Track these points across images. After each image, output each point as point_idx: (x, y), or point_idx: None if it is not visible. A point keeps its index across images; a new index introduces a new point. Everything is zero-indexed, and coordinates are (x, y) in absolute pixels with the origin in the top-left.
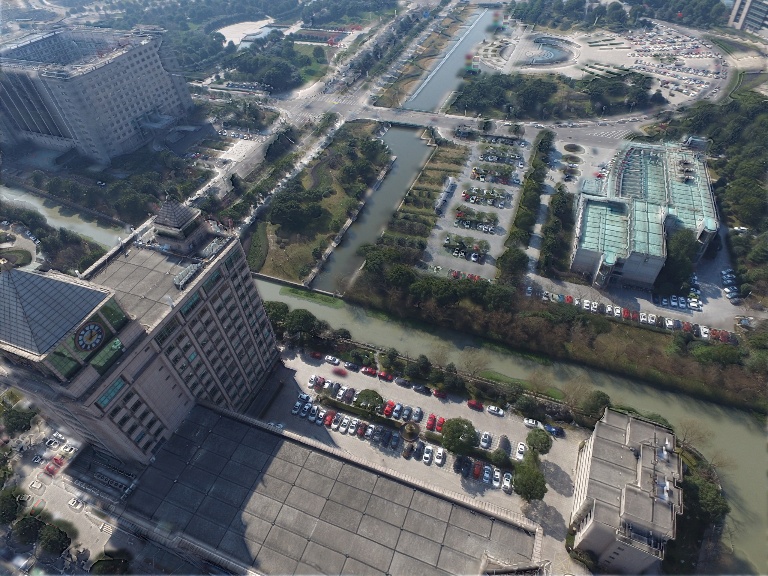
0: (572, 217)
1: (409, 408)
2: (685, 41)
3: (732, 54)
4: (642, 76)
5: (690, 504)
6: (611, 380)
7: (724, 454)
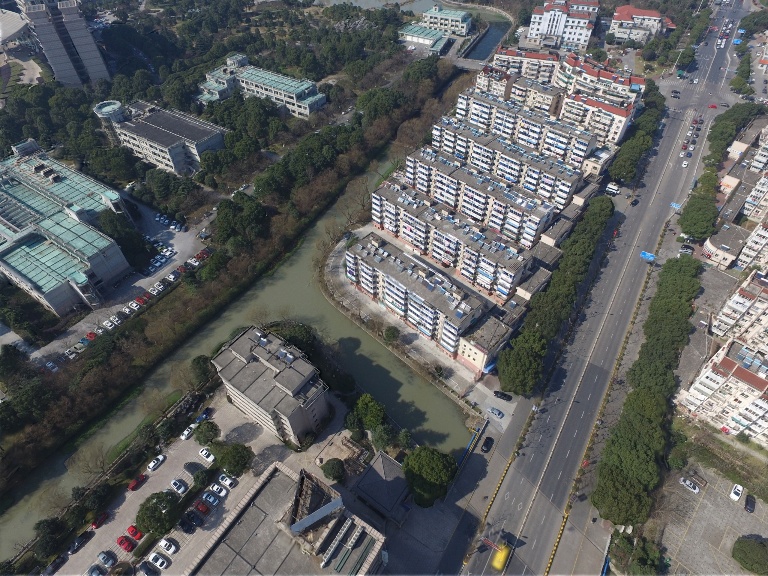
0: None
1: (92, 568)
2: None
3: None
4: None
5: (303, 348)
6: (190, 347)
7: (283, 308)
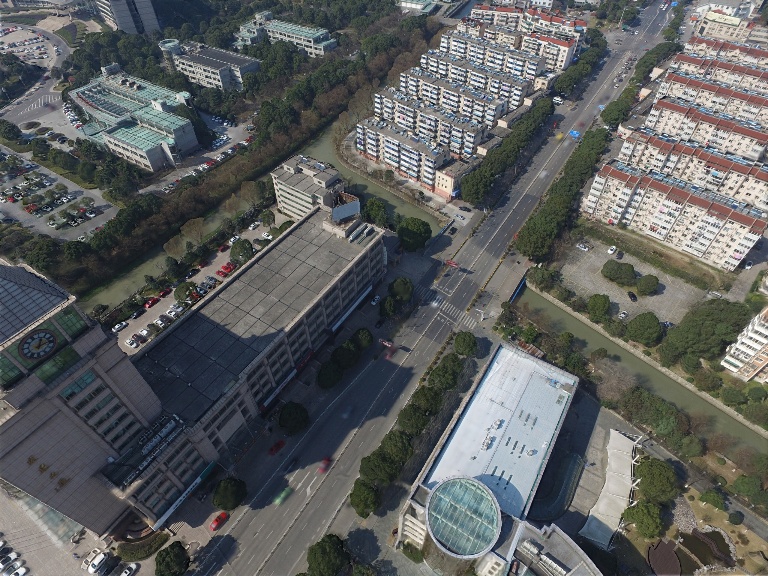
0: (105, 153)
1: (203, 283)
2: None
3: (25, 23)
4: None
5: None
6: None
7: None
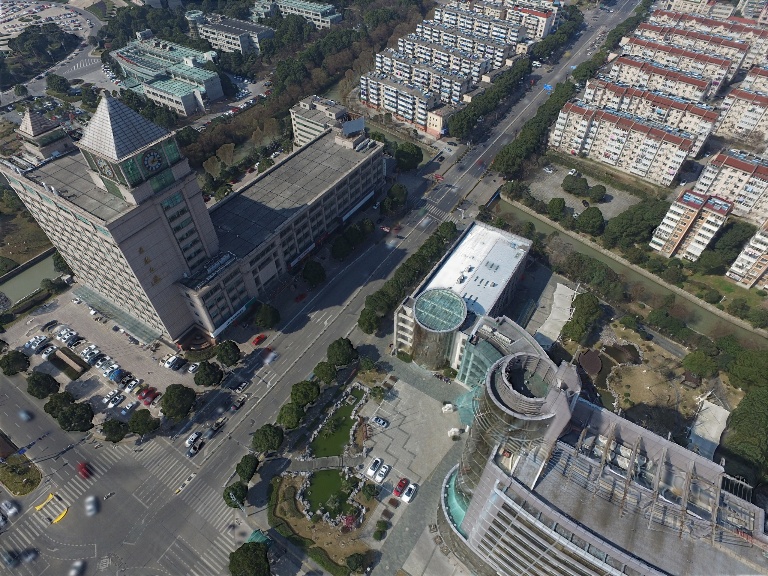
0: (144, 103)
1: None
2: (11, 5)
3: (58, 1)
4: (39, 26)
5: None
6: None
7: None
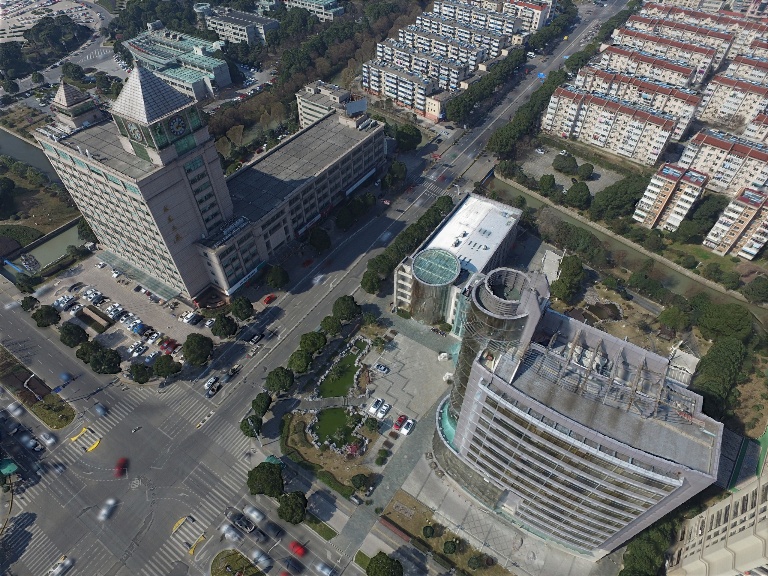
0: None
1: None
2: None
3: None
4: (52, 18)
5: None
6: None
7: None
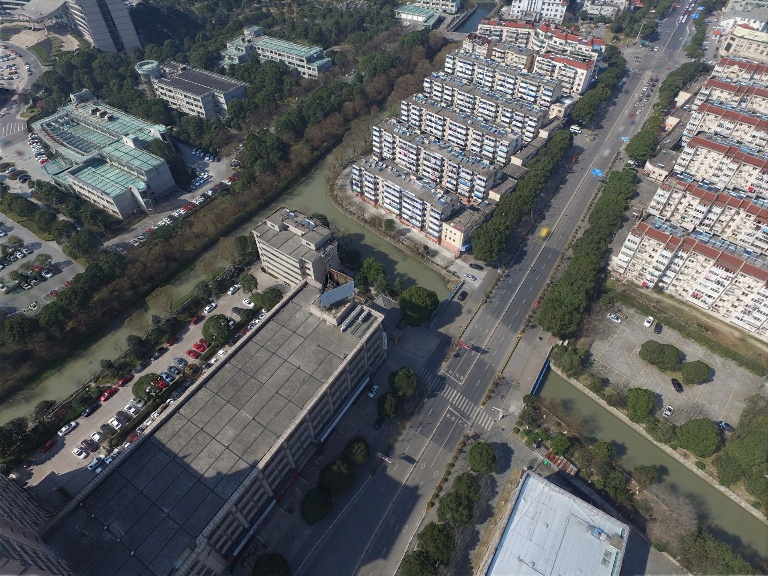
0: (70, 196)
1: (170, 367)
2: None
3: None
4: None
5: None
6: None
7: (303, 207)
